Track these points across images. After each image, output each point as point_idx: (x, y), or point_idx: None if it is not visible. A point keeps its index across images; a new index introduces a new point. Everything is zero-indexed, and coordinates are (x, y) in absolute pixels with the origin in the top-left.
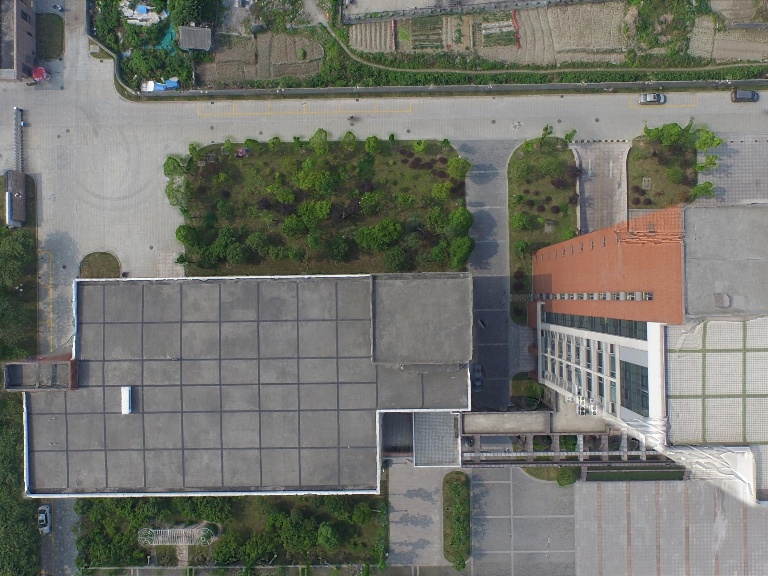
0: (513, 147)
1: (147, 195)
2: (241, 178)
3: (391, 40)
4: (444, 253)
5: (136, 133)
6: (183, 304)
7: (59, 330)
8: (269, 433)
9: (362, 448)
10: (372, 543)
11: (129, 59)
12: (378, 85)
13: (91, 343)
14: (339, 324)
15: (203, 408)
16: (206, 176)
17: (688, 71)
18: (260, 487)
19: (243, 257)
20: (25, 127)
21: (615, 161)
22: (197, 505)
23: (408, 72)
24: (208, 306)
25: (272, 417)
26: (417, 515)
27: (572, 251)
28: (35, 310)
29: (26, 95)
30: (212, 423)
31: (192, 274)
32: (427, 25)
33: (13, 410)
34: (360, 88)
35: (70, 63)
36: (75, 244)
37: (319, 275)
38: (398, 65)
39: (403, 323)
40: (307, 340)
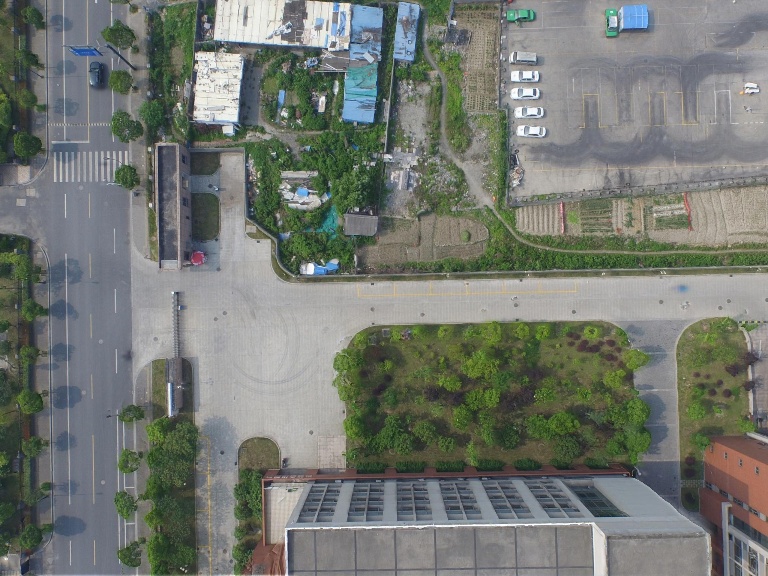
0: (681, 328)
1: (306, 379)
2: (403, 361)
3: (559, 223)
4: (621, 447)
5: (295, 315)
6: (397, 551)
7: (217, 517)
8: None
9: None
10: None
11: (289, 242)
12: (545, 267)
13: None
14: (560, 572)
15: None
16: (368, 360)
17: None
18: None
19: (412, 449)
20: (181, 310)
21: None
22: None
23: (575, 254)
24: (423, 553)
25: None
26: None
27: None
28: (193, 497)
29: (181, 277)
30: None
31: (354, 460)
32: (597, 209)
33: None
34: (527, 272)
35: (226, 244)
36: (233, 429)
37: (540, 523)
38: (565, 247)
39: None
40: None
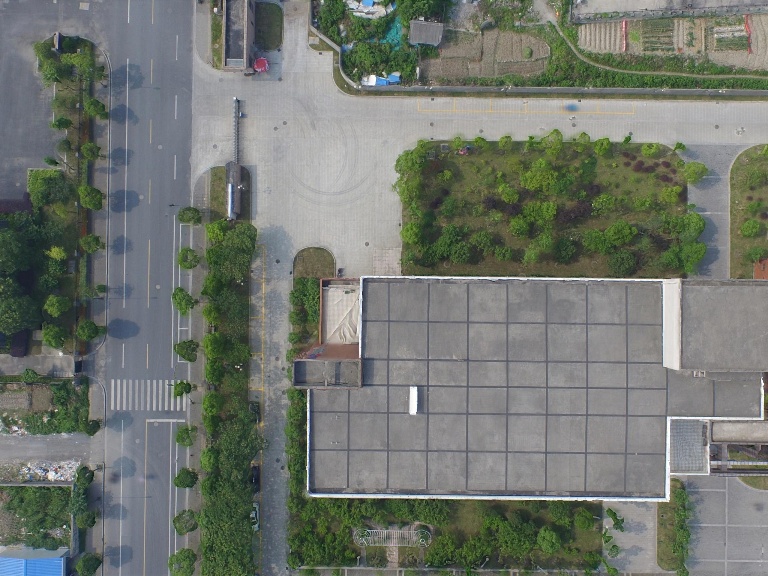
0: (736, 153)
1: (364, 191)
2: (460, 176)
3: (621, 41)
4: None
5: (354, 127)
6: (470, 304)
7: (271, 325)
8: (555, 437)
9: (650, 455)
10: (586, 549)
11: (352, 52)
12: (604, 86)
13: (375, 341)
14: (629, 328)
15: (489, 410)
16: (426, 173)
17: None
18: (544, 492)
19: (469, 256)
20: (242, 118)
21: None
22: (414, 506)
23: (635, 74)
24: (495, 307)
25: (559, 421)
26: (631, 521)
27: None
28: None
29: (243, 85)
30: (498, 426)
31: (409, 272)
32: (659, 27)
33: (237, 406)
34: None
35: (288, 54)
36: (289, 238)
37: (612, 278)
38: (625, 67)
39: (710, 330)
40: (596, 344)
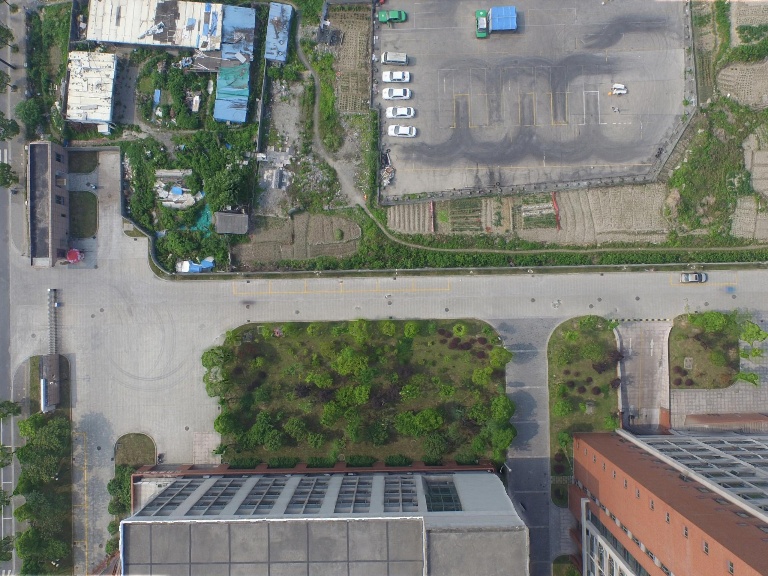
0: (553, 326)
1: (182, 375)
2: (278, 358)
3: (430, 222)
4: (486, 443)
5: (171, 312)
6: (231, 544)
7: (94, 512)
8: None
9: None
10: None
11: (164, 240)
12: (416, 266)
13: None
14: (390, 565)
15: None
16: (242, 357)
17: (730, 250)
18: None
19: (281, 445)
20: (59, 307)
21: (656, 340)
22: None
23: (447, 252)
24: (257, 546)
25: None
26: None
27: (625, 485)
28: (69, 492)
29: (59, 274)
30: None
31: (228, 456)
32: (466, 208)
33: None
34: (398, 270)
35: (104, 241)
36: (110, 425)
37: (370, 517)
38: (436, 245)
39: None
40: None
